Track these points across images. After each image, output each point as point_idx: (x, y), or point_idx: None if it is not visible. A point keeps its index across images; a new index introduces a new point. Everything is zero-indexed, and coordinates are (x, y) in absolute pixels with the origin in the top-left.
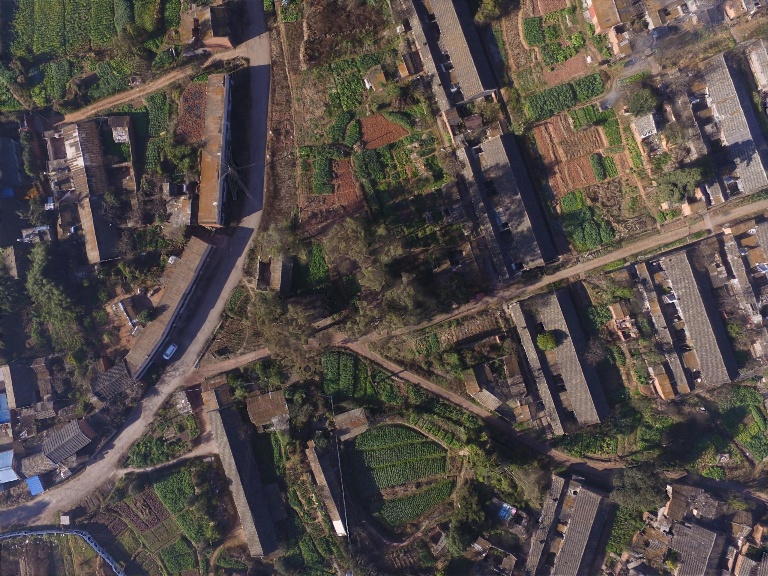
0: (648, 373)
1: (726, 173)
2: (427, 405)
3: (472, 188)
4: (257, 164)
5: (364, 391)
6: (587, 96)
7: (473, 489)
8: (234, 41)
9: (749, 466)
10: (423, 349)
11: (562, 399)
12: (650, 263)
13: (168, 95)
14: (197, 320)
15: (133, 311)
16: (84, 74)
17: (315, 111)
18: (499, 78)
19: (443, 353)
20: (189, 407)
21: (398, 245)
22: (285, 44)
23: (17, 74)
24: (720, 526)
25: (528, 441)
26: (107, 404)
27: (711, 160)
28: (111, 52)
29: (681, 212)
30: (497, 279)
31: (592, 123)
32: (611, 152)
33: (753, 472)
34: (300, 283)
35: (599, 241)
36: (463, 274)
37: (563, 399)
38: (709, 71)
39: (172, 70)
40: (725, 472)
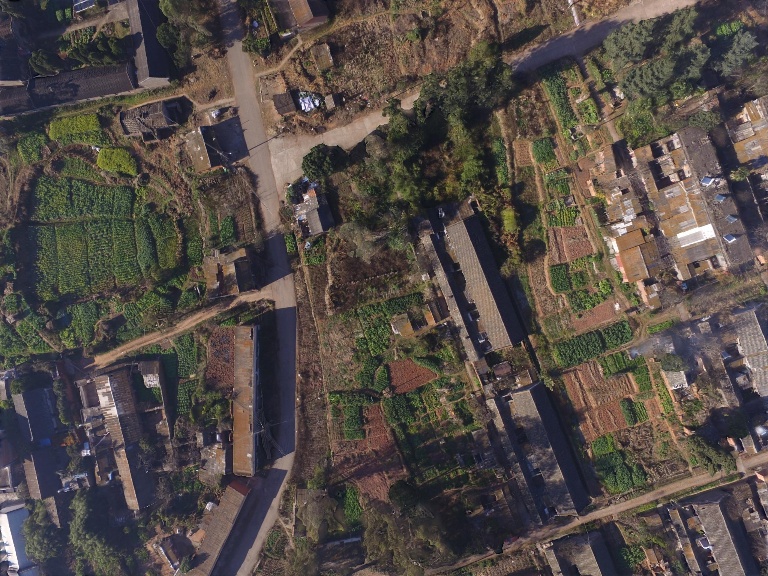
0: None
1: (758, 423)
2: None
3: (503, 437)
4: (287, 406)
5: None
6: (616, 344)
7: None
8: (258, 283)
9: None
10: None
11: None
12: (683, 509)
13: (196, 338)
14: (236, 559)
15: (174, 554)
16: (111, 315)
17: (343, 356)
18: (527, 325)
19: None
20: None
21: (437, 540)
22: (310, 287)
23: (45, 320)
24: None
25: None
26: None
27: (744, 419)
28: (136, 292)
29: None
30: (530, 519)
31: (622, 370)
32: (641, 399)
33: None
34: None
35: (631, 485)
36: (496, 519)
37: None
38: (740, 325)
39: (198, 311)
40: None
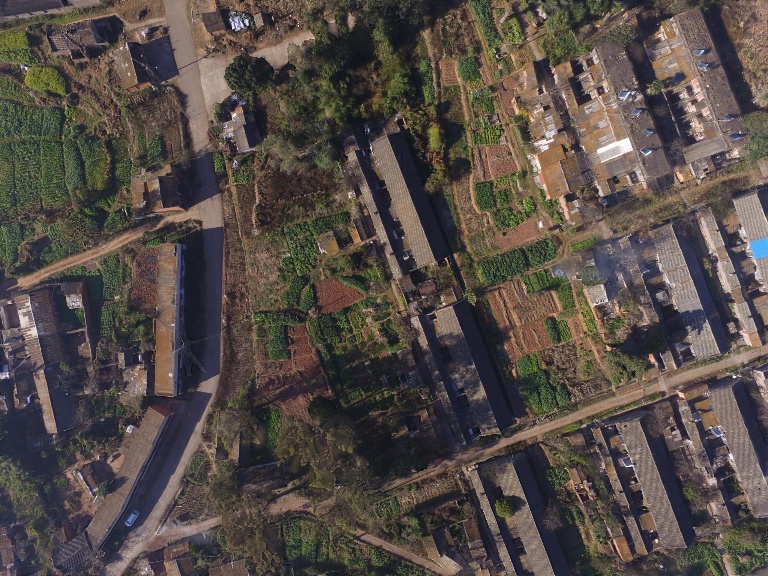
0: (607, 532)
1: (678, 340)
2: (390, 567)
3: (427, 356)
4: (213, 328)
5: (326, 556)
6: (539, 262)
7: None
8: (186, 203)
9: None
10: (384, 512)
11: (522, 562)
12: (606, 428)
13: (121, 259)
14: (158, 486)
15: (93, 480)
16: (36, 236)
17: (269, 276)
18: (452, 243)
19: (404, 516)
20: (152, 574)
21: (348, 444)
22: (237, 207)
23: None
24: None
25: None
26: (70, 574)
27: (662, 333)
28: (62, 213)
29: None
30: (455, 442)
31: (545, 288)
32: (565, 317)
33: None
34: (259, 449)
35: (555, 405)
36: (421, 440)
37: (523, 562)
38: (659, 240)
39: (125, 232)
40: None
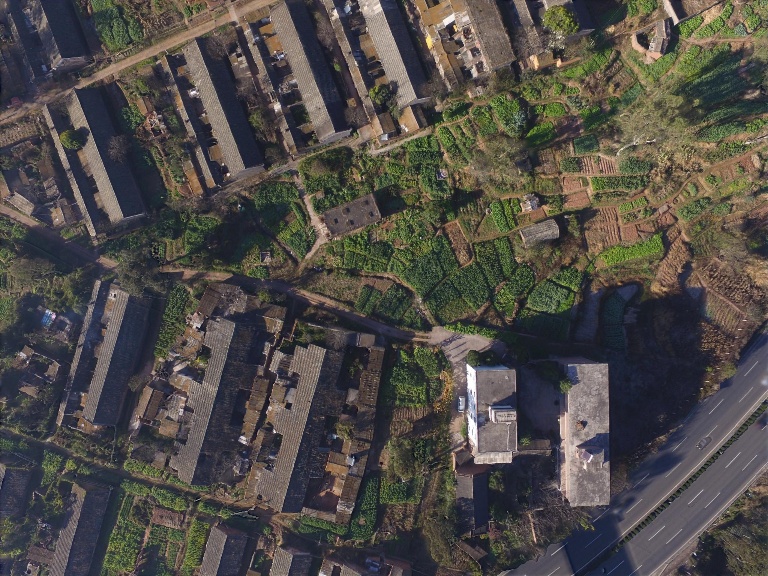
0: None
1: None
2: None
3: None
4: None
5: None
6: None
7: (22, 299)
8: None
9: (292, 264)
10: None
11: (96, 200)
12: (173, 56)
13: None
14: None
15: None
16: None
17: None
18: None
19: None
20: None
21: None
22: None
23: None
24: (253, 321)
25: (76, 249)
26: None
27: None
28: None
29: (207, 5)
30: None
31: None
32: None
33: (296, 270)
34: None
35: (127, 39)
36: None
37: (97, 200)
38: None
39: None
40: (269, 271)
